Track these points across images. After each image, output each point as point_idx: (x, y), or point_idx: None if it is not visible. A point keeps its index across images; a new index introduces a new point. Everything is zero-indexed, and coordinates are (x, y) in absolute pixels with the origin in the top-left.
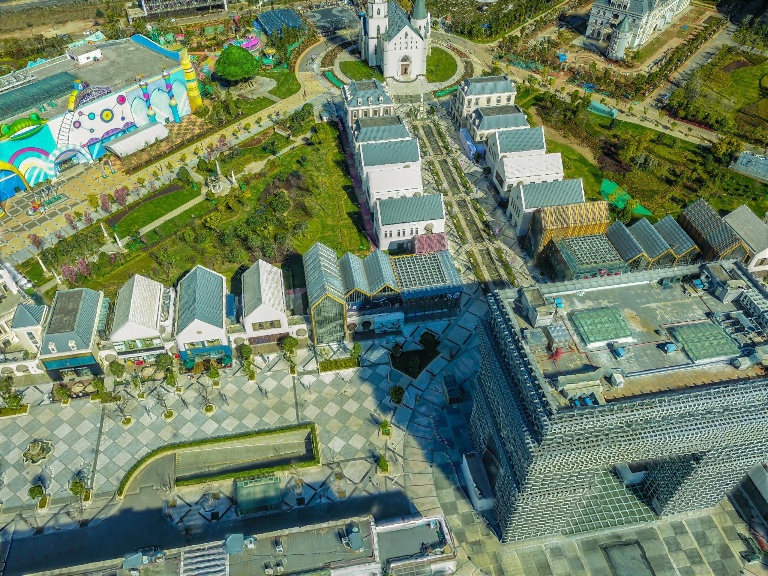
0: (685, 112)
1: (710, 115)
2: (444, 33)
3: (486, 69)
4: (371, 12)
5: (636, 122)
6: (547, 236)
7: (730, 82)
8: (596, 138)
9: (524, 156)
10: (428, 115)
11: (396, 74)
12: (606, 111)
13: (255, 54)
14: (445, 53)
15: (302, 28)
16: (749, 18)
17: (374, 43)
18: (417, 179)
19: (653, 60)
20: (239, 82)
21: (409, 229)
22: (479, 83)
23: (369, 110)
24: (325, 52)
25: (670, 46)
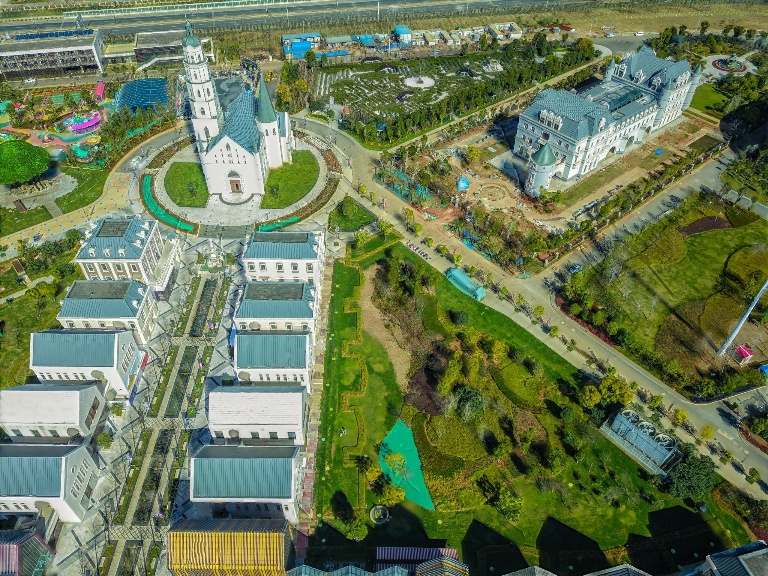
0: (581, 307)
1: (610, 323)
2: (335, 129)
3: (353, 192)
4: (193, 111)
5: (507, 312)
6: (179, 574)
7: (682, 255)
8: (430, 337)
9: (243, 392)
10: (225, 263)
11: (225, 191)
12: (469, 288)
13: (75, 142)
14: (313, 162)
15: (163, 107)
16: (752, 149)
17: (205, 147)
18: (72, 409)
19: (587, 203)
20: (21, 184)
21: (11, 503)
22: (263, 243)
23: (108, 264)
24: (170, 144)
25: (623, 181)
